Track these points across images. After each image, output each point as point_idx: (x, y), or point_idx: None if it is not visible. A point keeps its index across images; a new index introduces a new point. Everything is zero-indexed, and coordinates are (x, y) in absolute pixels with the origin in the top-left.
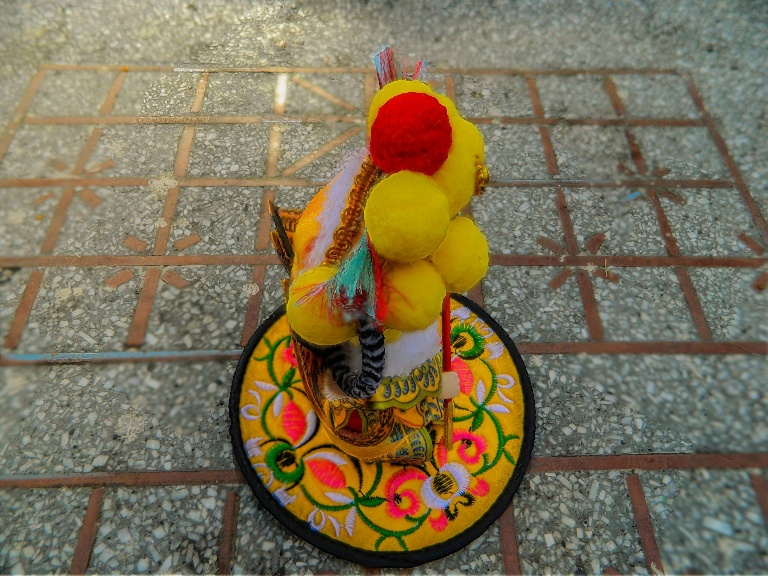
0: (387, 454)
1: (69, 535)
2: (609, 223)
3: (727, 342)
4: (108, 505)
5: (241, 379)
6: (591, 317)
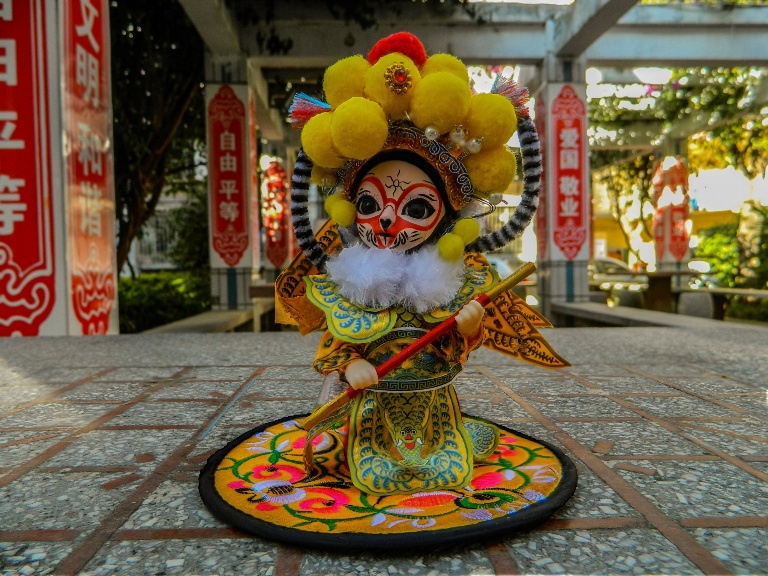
0: None
1: None
2: None
3: None
4: None
5: None
6: None
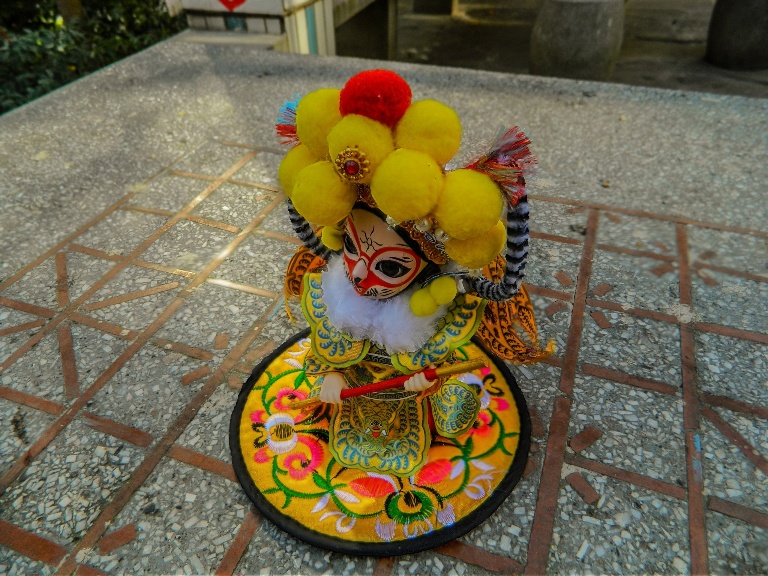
0: None
1: None
2: None
3: None
4: None
5: None
6: None
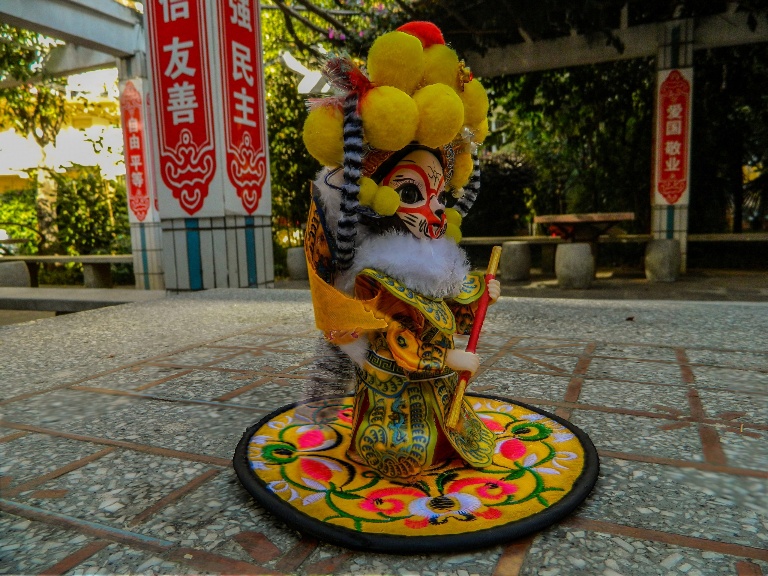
0: (382, 436)
1: (63, 462)
2: (754, 409)
3: None
4: (110, 456)
5: (285, 410)
6: (710, 450)
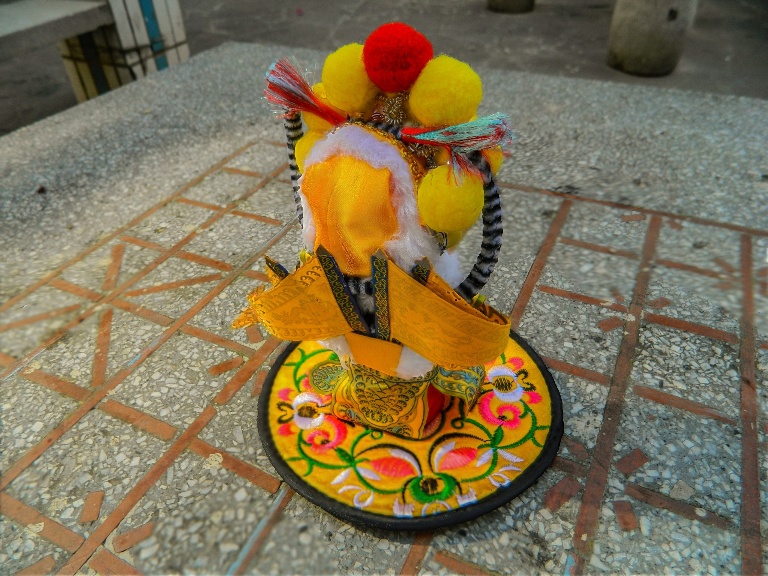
0: (472, 391)
1: None
2: None
3: None
4: None
5: (321, 495)
6: None
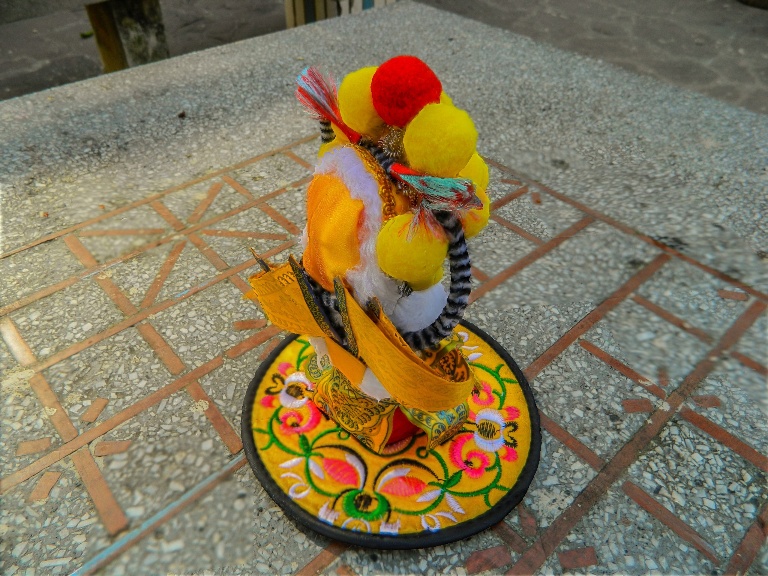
0: (442, 428)
1: None
2: None
3: (552, 239)
4: None
5: (266, 472)
6: None
